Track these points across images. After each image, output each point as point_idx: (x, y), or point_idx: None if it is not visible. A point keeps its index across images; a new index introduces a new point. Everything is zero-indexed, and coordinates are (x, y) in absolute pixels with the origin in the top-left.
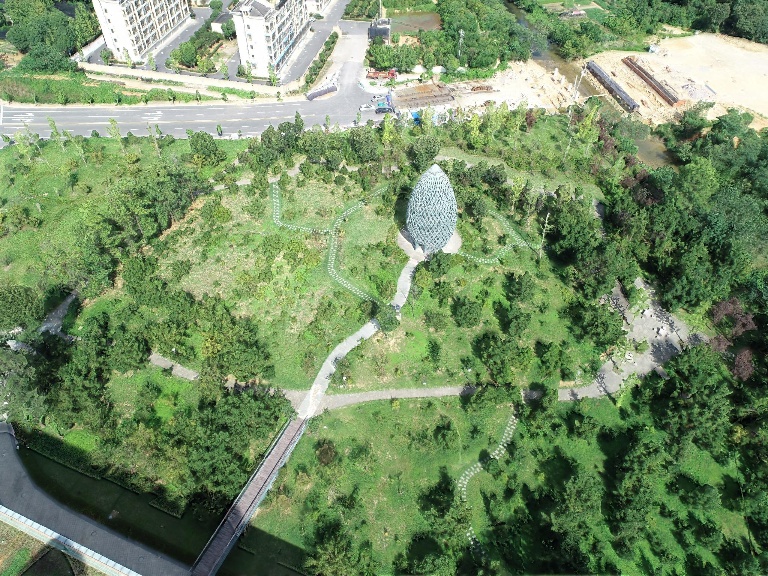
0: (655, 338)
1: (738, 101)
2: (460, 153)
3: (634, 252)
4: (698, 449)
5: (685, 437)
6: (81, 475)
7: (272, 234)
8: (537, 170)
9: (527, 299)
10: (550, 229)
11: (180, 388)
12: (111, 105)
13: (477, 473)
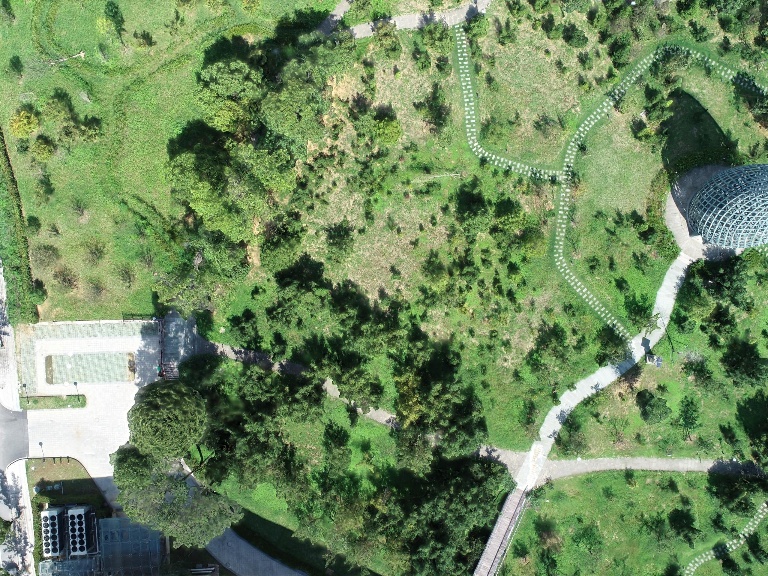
0: None
1: None
2: None
3: None
4: None
5: None
6: (283, 529)
7: (468, 175)
8: None
9: None
10: None
11: (371, 434)
12: None
13: (708, 561)
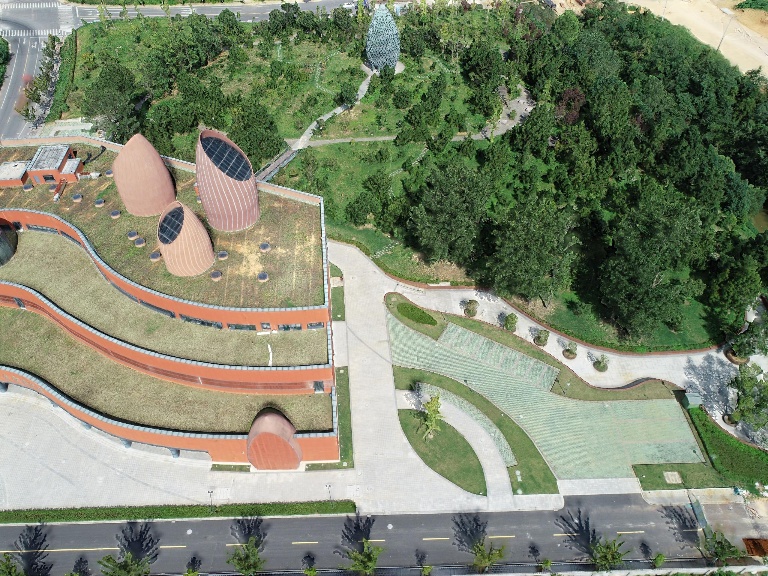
0: (523, 113)
1: (631, 1)
2: None
3: (519, 70)
4: (536, 159)
5: (524, 146)
6: None
7: None
8: (466, 35)
9: (442, 91)
10: (465, 59)
11: None
12: (157, 6)
13: (400, 173)
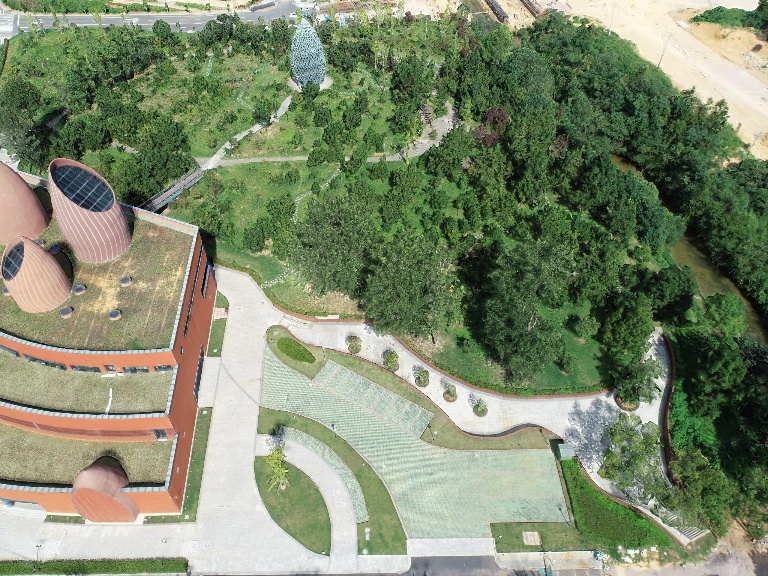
0: (446, 132)
1: (586, 13)
2: (354, 40)
3: (448, 87)
4: (449, 182)
5: (436, 169)
6: None
7: None
8: (405, 48)
9: (364, 109)
10: (394, 74)
11: None
12: (101, 14)
13: (308, 195)
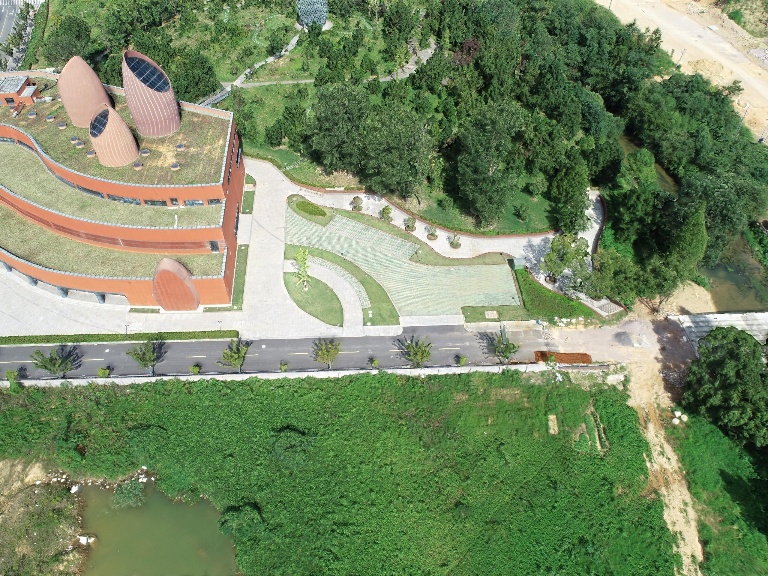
0: None
1: None
2: None
3: (431, 26)
4: (432, 95)
5: (421, 83)
6: None
7: None
8: (394, 0)
9: (360, 43)
10: (385, 17)
11: None
12: None
13: None
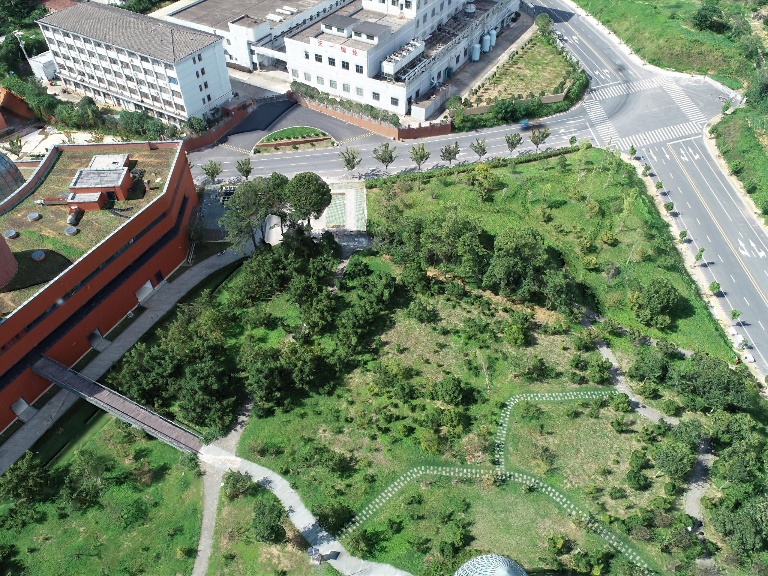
0: None
1: None
2: None
3: None
4: None
5: None
6: None
7: (489, 394)
8: None
9: None
10: None
11: (272, 343)
12: (754, 209)
13: None
